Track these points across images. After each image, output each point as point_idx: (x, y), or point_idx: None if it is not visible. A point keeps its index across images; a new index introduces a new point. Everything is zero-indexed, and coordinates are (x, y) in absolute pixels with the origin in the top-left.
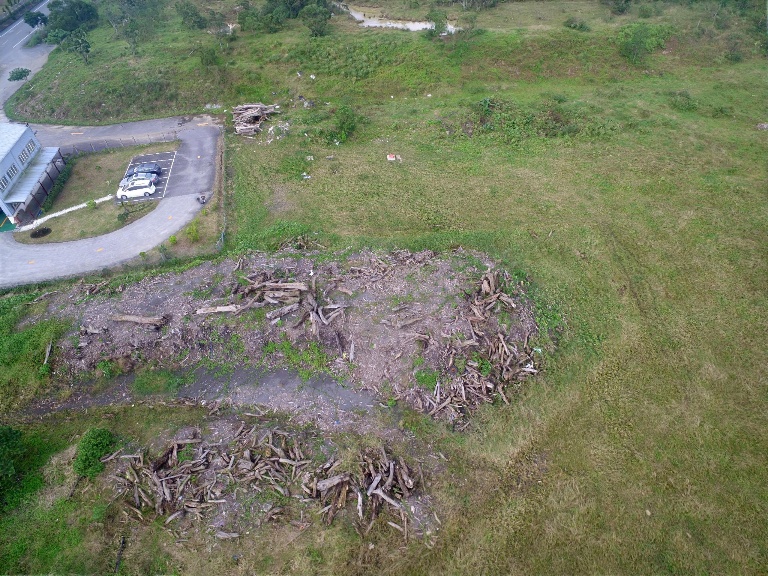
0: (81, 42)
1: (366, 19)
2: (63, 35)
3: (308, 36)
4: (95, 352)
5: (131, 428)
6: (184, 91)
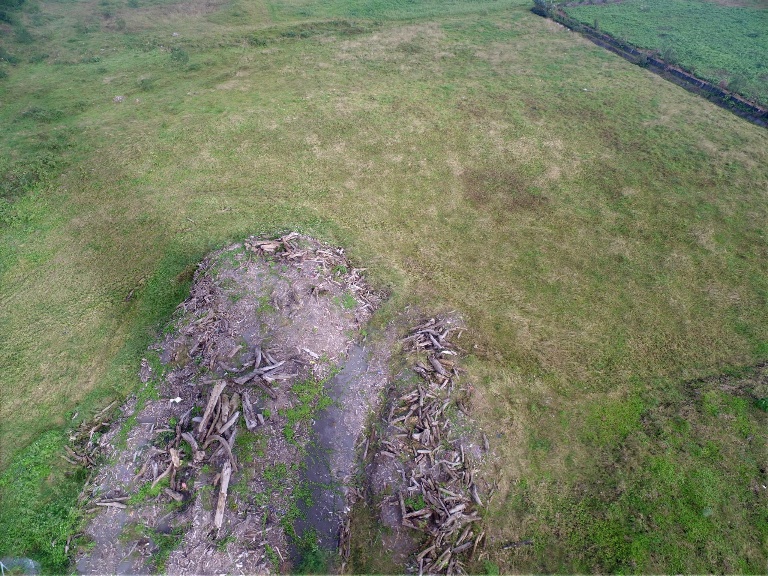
0: None
1: None
2: None
3: None
4: None
5: None
6: None
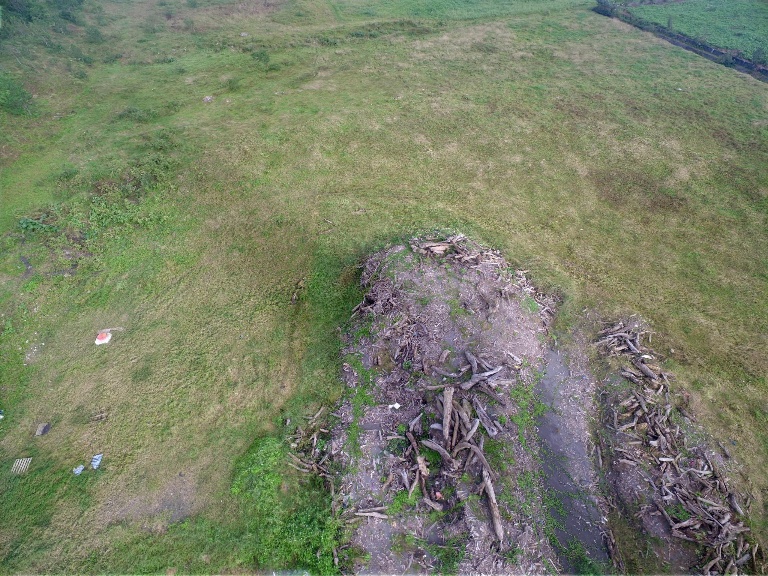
0: None
1: None
2: None
3: None
4: None
5: None
6: None
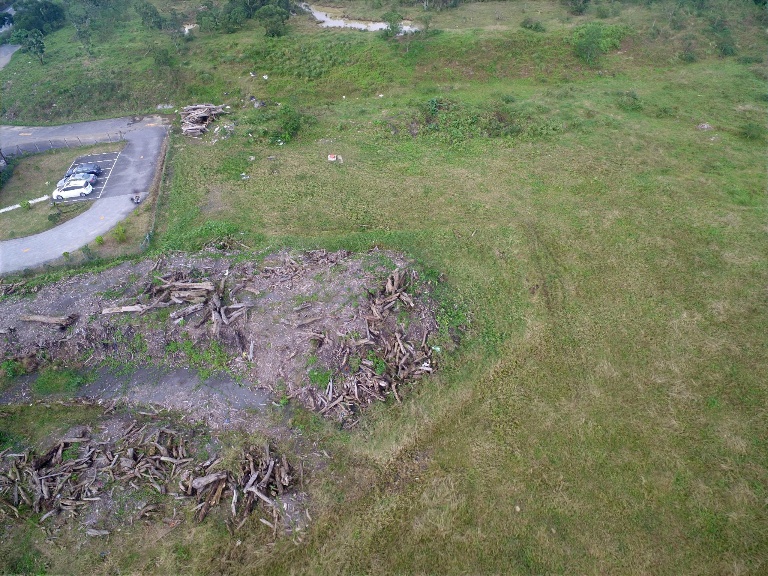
0: (35, 42)
1: (327, 19)
2: (26, 35)
3: (262, 36)
4: (0, 352)
5: (25, 427)
6: (136, 91)
